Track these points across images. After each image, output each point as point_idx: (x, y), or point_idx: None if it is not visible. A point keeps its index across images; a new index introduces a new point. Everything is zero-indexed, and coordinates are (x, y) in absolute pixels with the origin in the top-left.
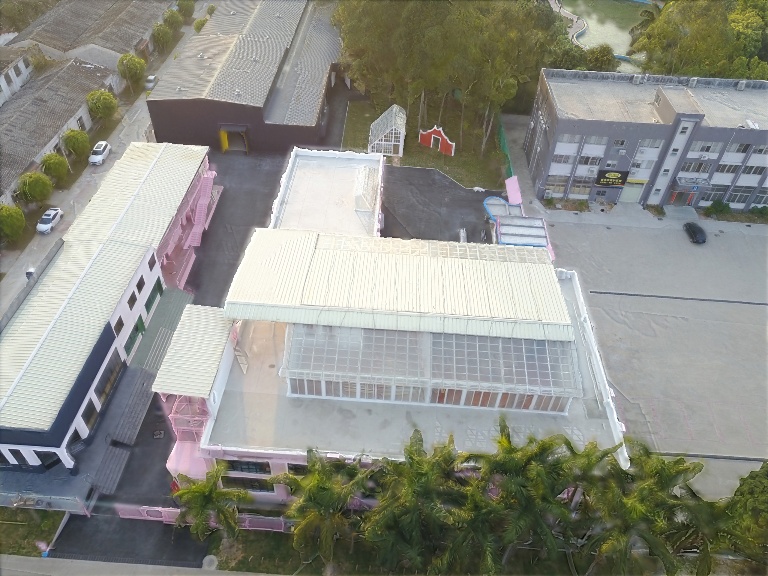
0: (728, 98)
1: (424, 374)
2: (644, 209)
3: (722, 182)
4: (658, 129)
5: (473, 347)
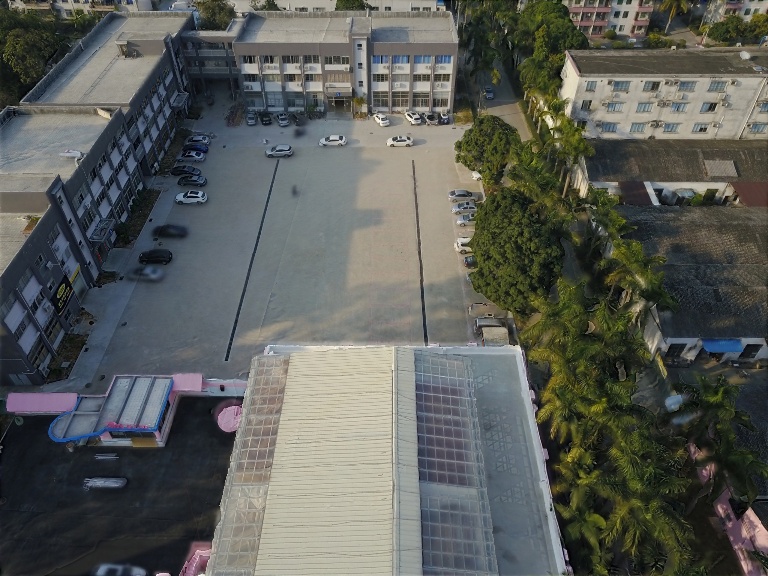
0: (2, 156)
1: (472, 495)
2: (101, 287)
3: (106, 211)
4: (48, 219)
5: (431, 440)
